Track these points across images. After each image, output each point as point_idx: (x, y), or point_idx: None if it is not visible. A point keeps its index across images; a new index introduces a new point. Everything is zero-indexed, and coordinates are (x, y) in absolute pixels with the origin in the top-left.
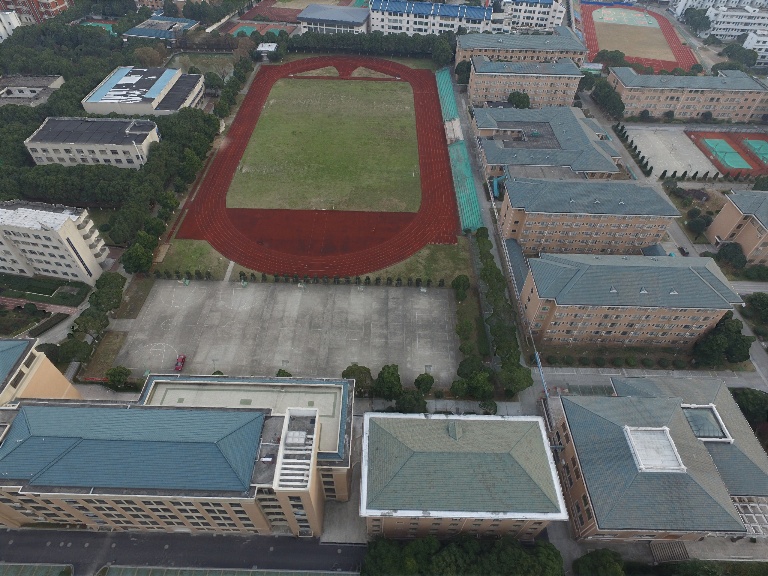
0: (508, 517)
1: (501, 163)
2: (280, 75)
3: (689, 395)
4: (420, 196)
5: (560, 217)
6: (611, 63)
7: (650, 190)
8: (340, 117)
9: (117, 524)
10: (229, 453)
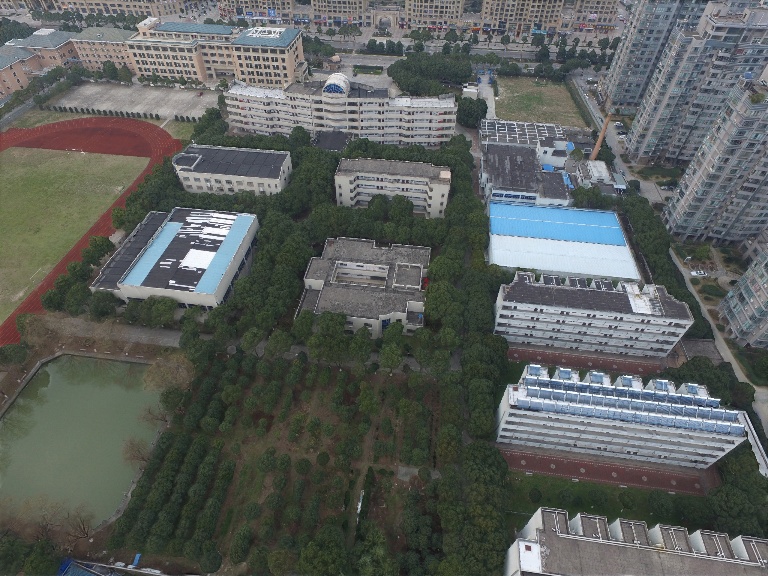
0: None
1: None
2: None
3: (7, 49)
4: None
5: None
6: None
7: None
8: None
9: None
10: None
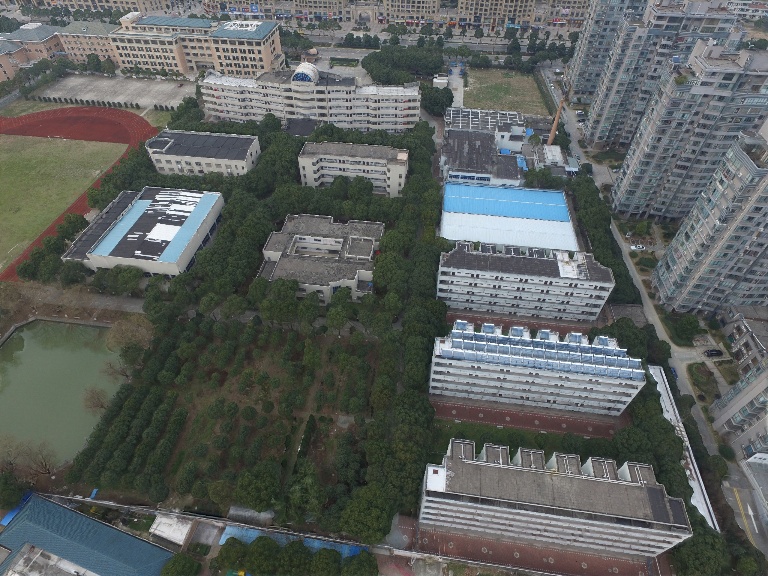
0: None
1: None
2: None
3: None
4: None
5: None
6: None
7: None
8: None
9: None
10: None
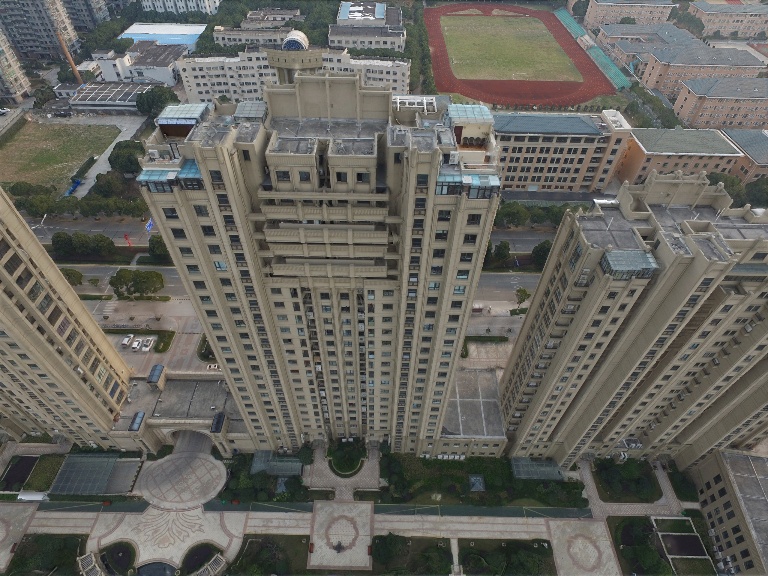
0: (716, 154)
1: (635, 52)
2: (440, 14)
3: None
4: (580, 74)
5: (690, 69)
6: (686, 3)
7: (746, 52)
8: (501, 36)
9: (505, 181)
10: (586, 122)
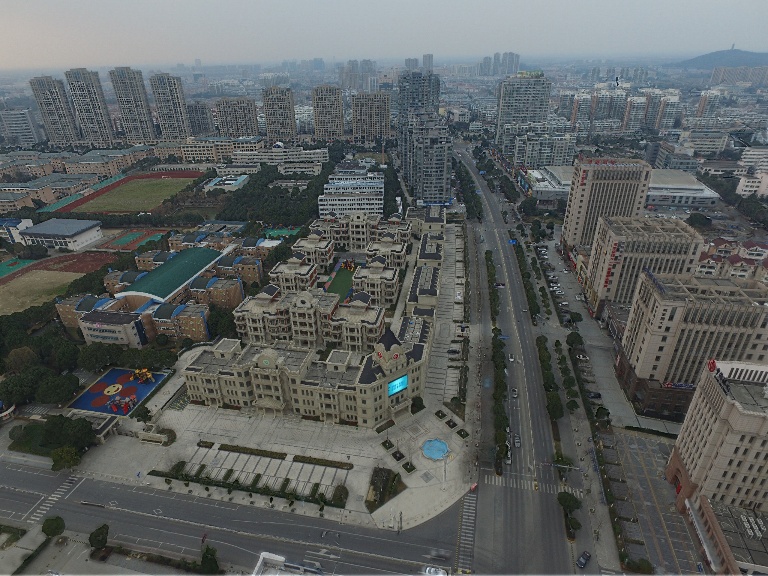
0: None
1: None
2: None
3: None
4: None
5: None
6: None
7: None
8: None
9: None
10: None
